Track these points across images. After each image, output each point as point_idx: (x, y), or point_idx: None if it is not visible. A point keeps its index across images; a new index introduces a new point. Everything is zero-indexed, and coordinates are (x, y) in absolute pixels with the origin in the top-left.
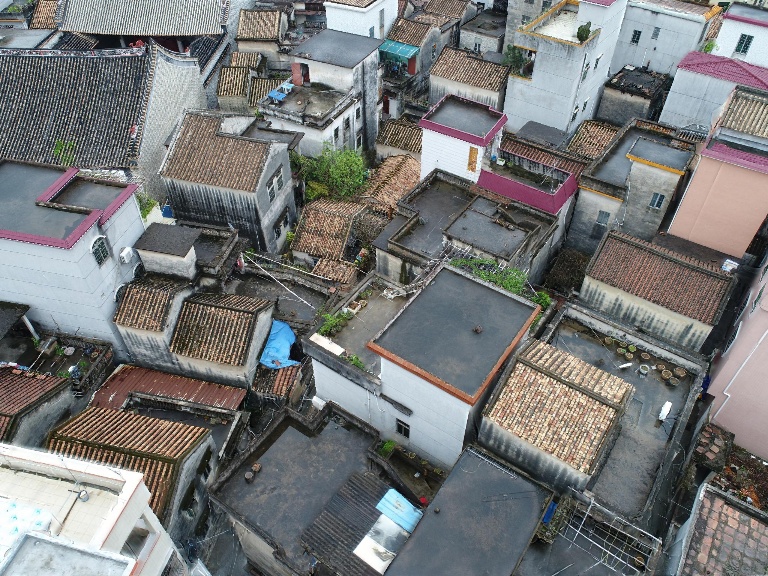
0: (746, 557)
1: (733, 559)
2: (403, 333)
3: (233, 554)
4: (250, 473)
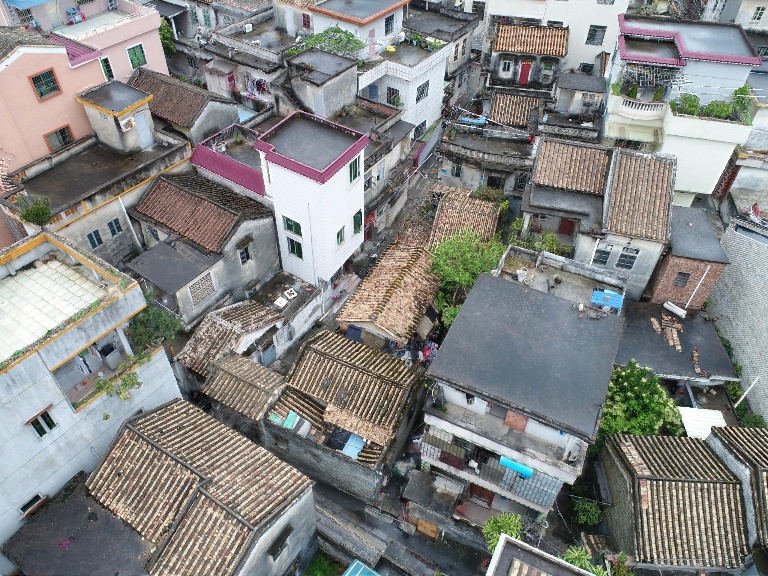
0: (250, 2)
1: (255, 2)
2: (392, 2)
3: (469, 70)
4: (463, 24)
